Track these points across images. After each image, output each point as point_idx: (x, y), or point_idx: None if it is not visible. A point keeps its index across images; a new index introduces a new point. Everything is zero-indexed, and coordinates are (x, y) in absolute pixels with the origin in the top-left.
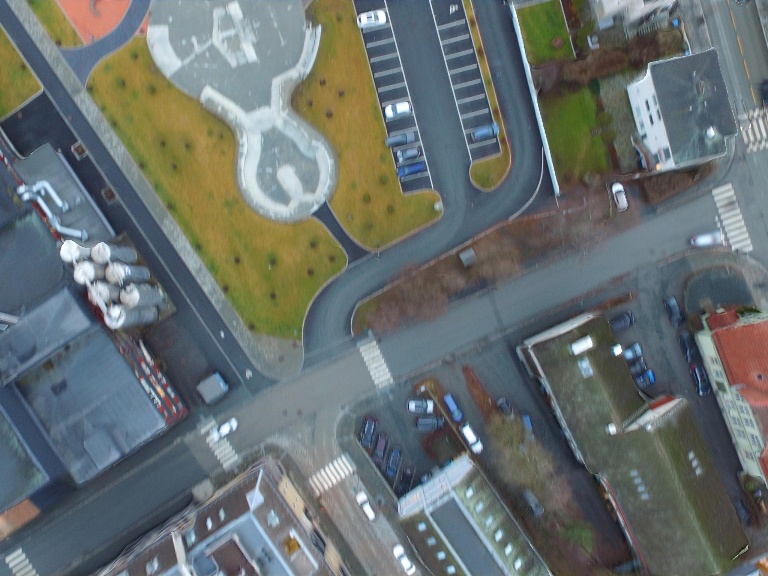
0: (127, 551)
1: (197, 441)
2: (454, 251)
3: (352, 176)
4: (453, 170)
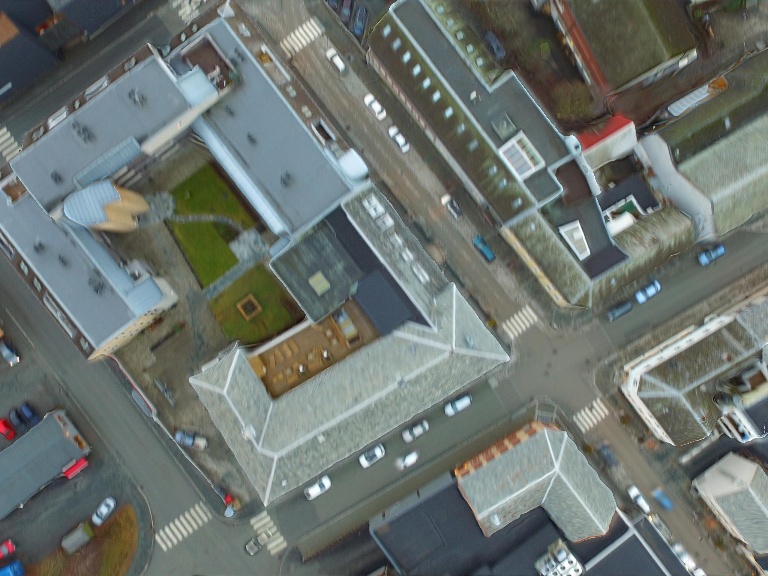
0: None
1: (170, 14)
2: None
3: None
4: None
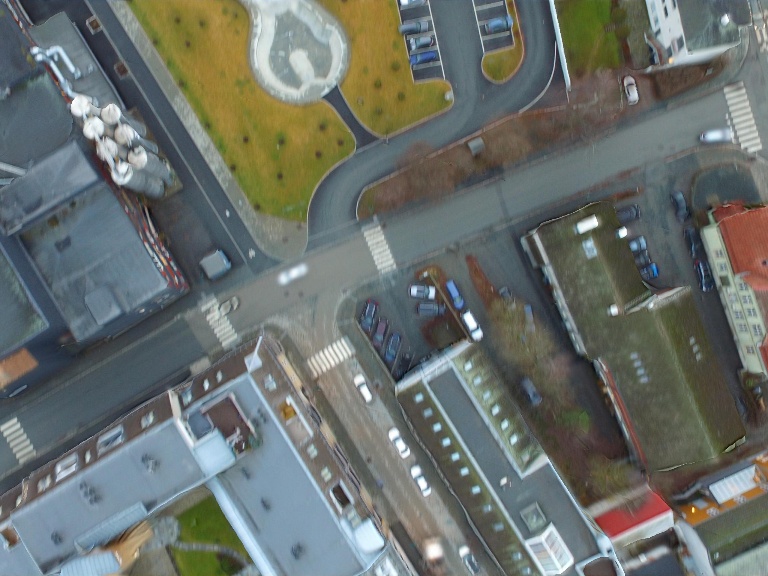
0: (122, 416)
1: (197, 318)
2: (463, 141)
3: (364, 61)
4: (465, 61)
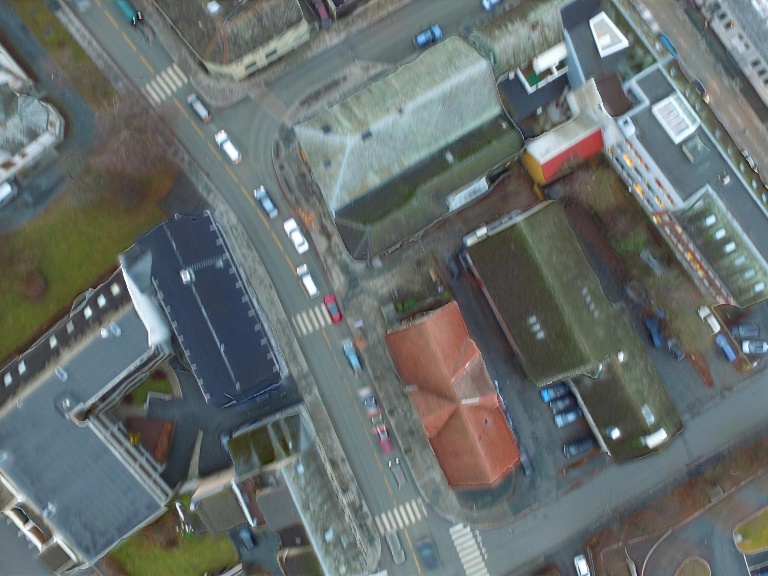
0: None
1: None
2: (723, 496)
3: None
4: (727, 574)
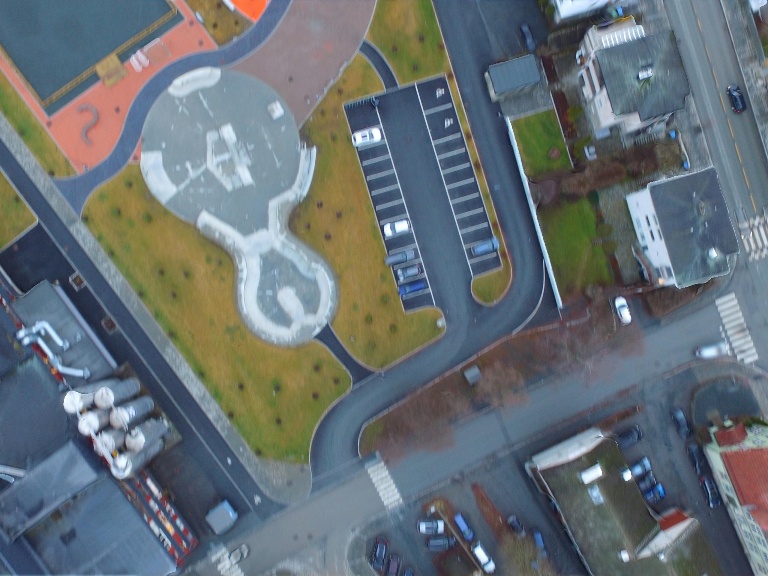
0: None
1: (208, 569)
2: (458, 368)
3: (353, 297)
4: (454, 286)
